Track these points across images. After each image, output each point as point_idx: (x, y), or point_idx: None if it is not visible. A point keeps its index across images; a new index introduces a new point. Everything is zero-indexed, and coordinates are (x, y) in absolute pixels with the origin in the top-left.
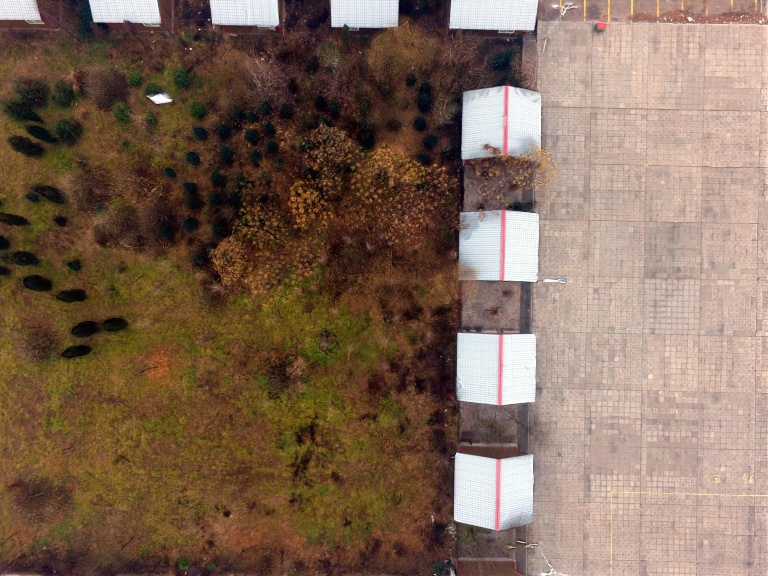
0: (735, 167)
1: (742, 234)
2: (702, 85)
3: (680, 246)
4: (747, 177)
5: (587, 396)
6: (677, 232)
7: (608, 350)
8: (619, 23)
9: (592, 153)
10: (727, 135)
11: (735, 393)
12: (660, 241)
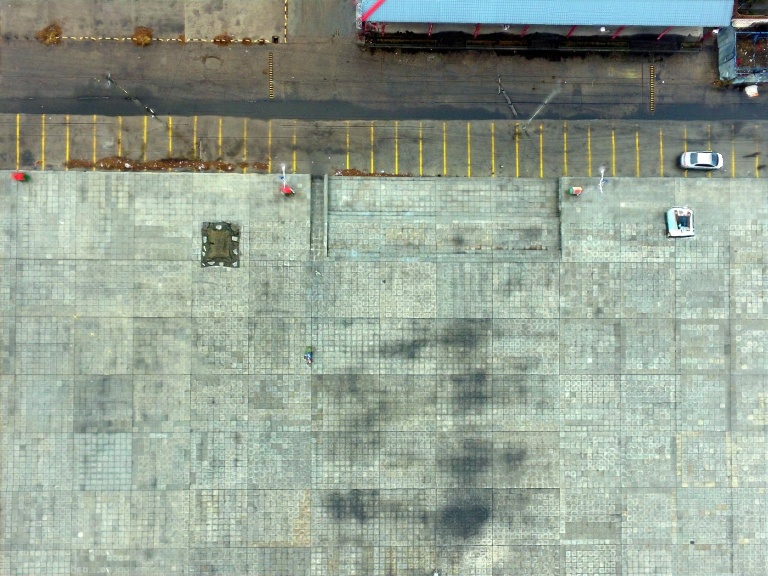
0: (168, 317)
1: (175, 385)
2: (132, 234)
3: (111, 399)
4: (180, 327)
5: (13, 558)
6: (108, 385)
7: (36, 509)
8: (45, 172)
9: (18, 305)
10: (158, 285)
11: (168, 549)
12: (90, 394)
